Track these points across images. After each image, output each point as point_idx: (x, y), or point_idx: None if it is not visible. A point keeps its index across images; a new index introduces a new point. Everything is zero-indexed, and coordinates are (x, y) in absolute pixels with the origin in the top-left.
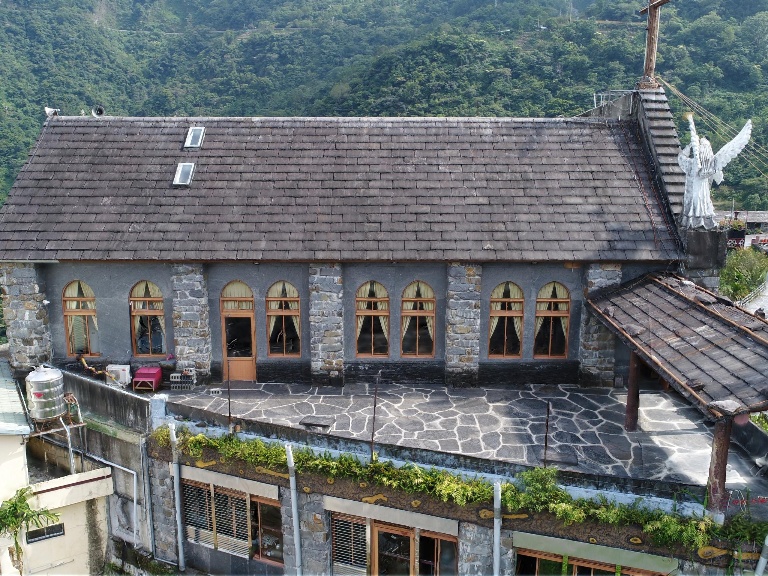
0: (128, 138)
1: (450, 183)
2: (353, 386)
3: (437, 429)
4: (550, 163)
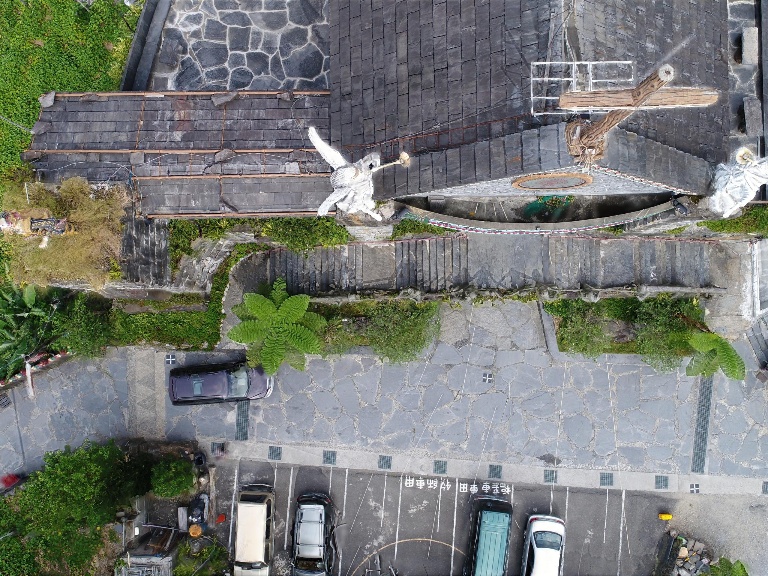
0: None
1: None
2: None
3: None
4: (462, 5)
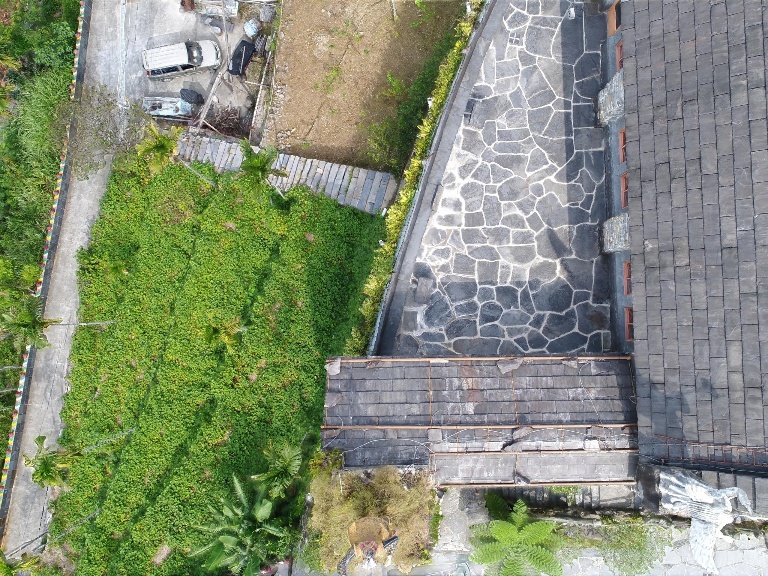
0: None
1: (764, 195)
2: (597, 136)
3: (503, 211)
4: None
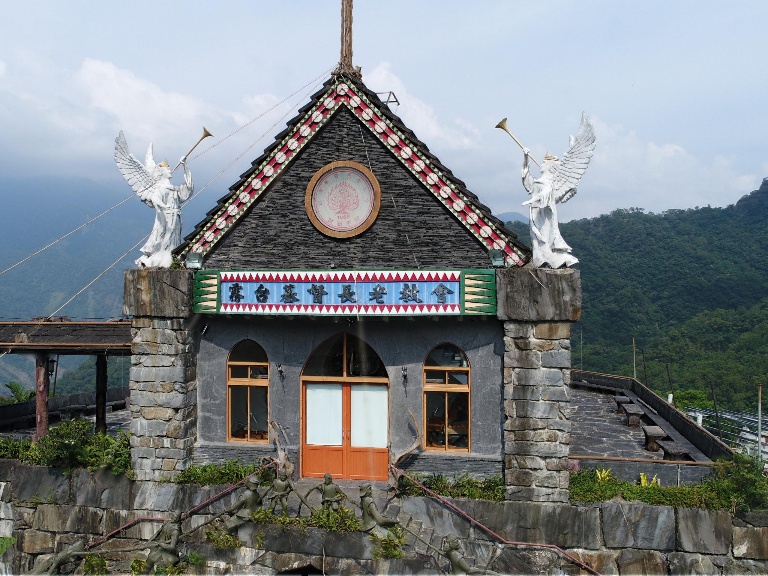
0: None
1: None
2: None
3: None
4: None
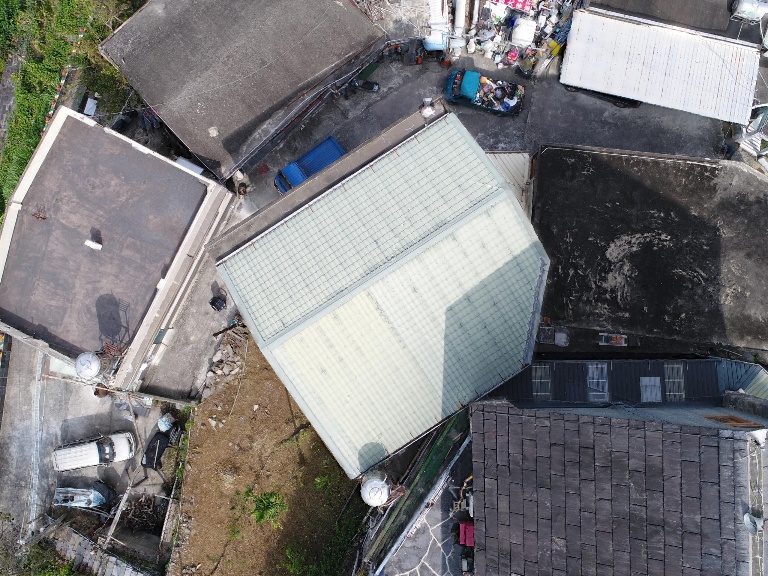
0: (692, 571)
1: None
2: None
3: None
4: None
